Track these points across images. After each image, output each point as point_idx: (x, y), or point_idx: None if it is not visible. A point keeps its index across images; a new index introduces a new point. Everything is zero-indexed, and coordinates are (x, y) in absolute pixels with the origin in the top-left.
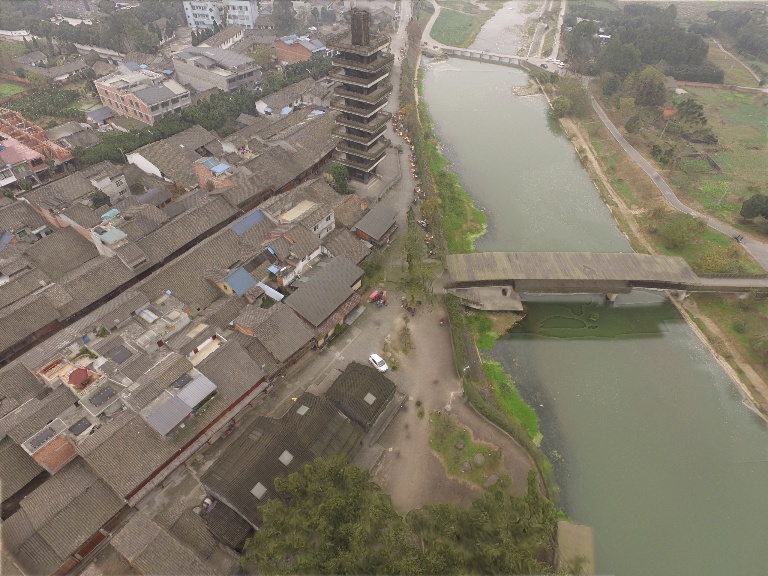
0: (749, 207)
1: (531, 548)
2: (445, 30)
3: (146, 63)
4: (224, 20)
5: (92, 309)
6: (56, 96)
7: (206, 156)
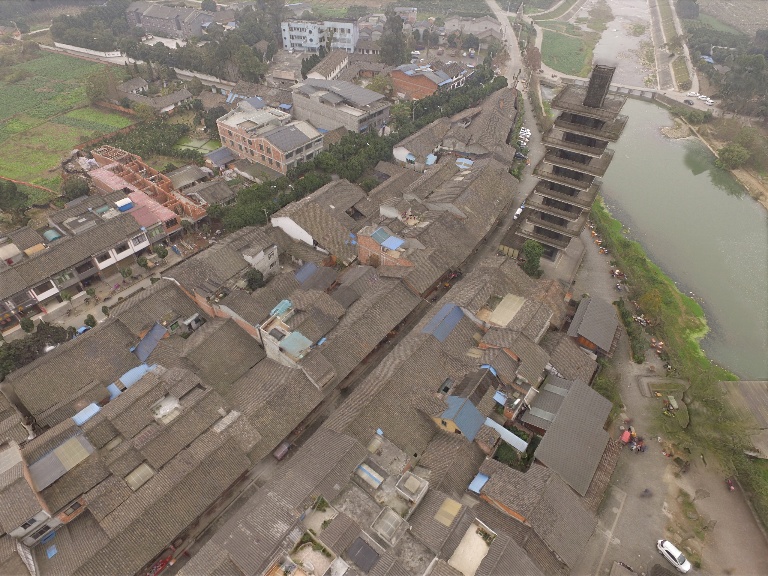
0: None
1: None
2: (555, 55)
3: (260, 95)
4: (328, 44)
5: (278, 445)
6: (164, 130)
7: (354, 216)
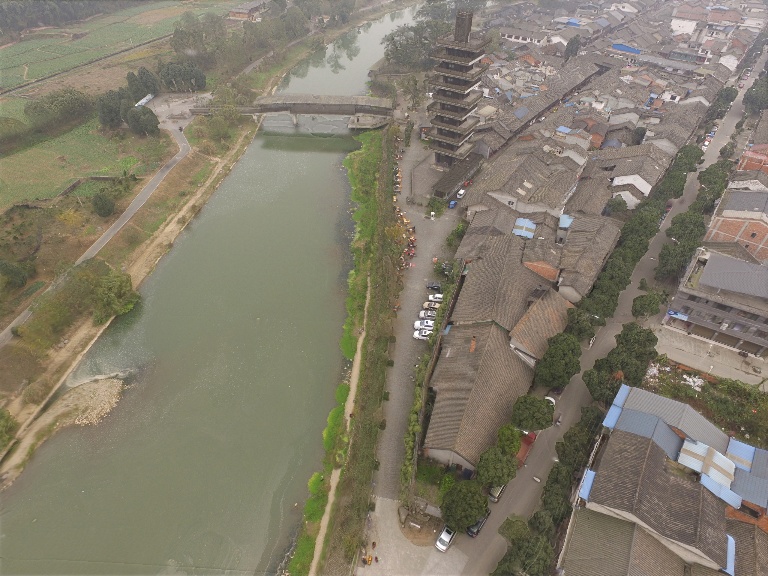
0: None
1: None
2: None
3: None
4: None
5: None
6: None
7: None
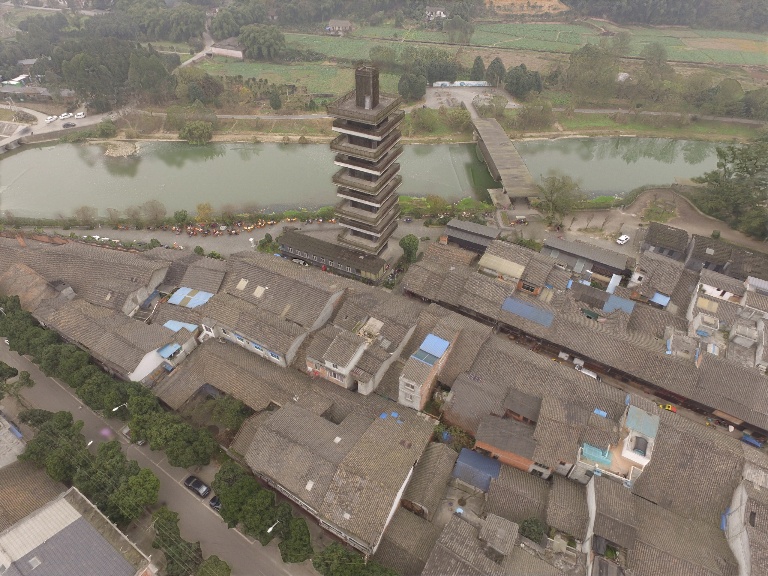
0: (407, 91)
1: (761, 145)
2: None
3: None
4: None
5: None
6: None
7: None
